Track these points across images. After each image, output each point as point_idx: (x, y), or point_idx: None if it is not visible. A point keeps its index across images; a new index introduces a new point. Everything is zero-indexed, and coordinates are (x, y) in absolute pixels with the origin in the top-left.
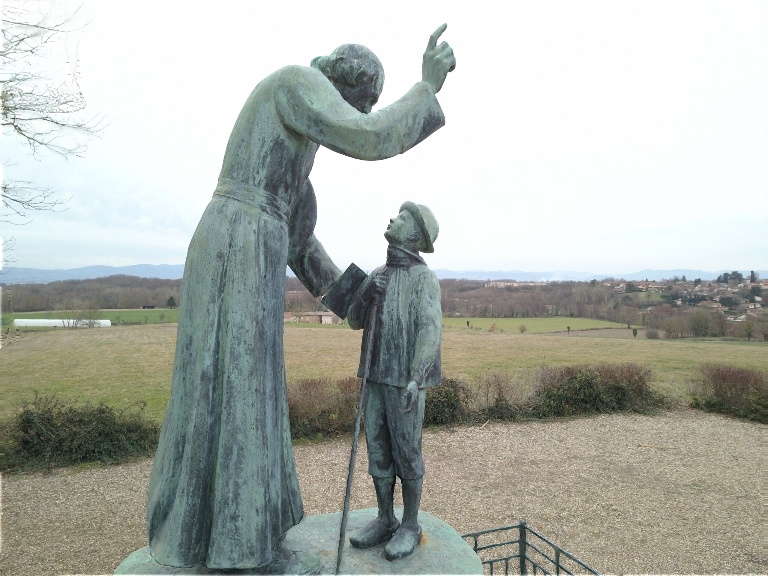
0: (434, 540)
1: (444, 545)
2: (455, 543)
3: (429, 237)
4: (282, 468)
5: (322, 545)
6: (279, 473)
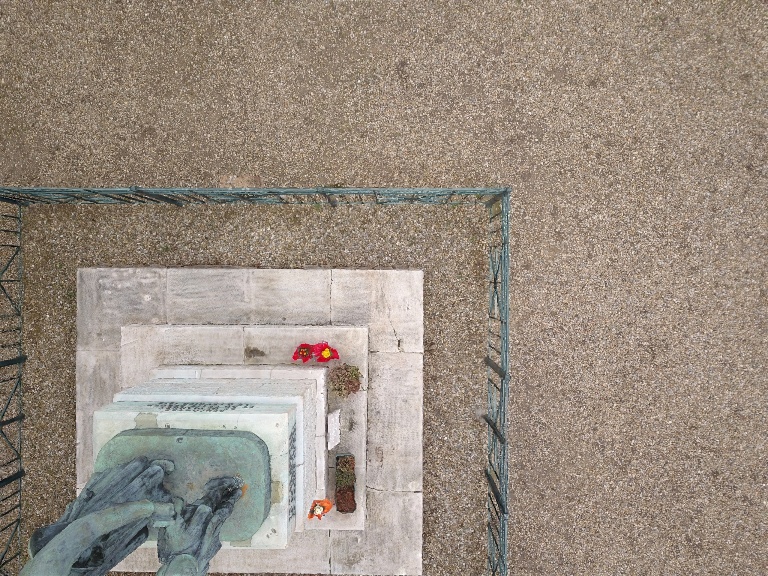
0: (248, 497)
1: (250, 504)
2: (257, 504)
3: None
4: None
5: (193, 478)
6: None
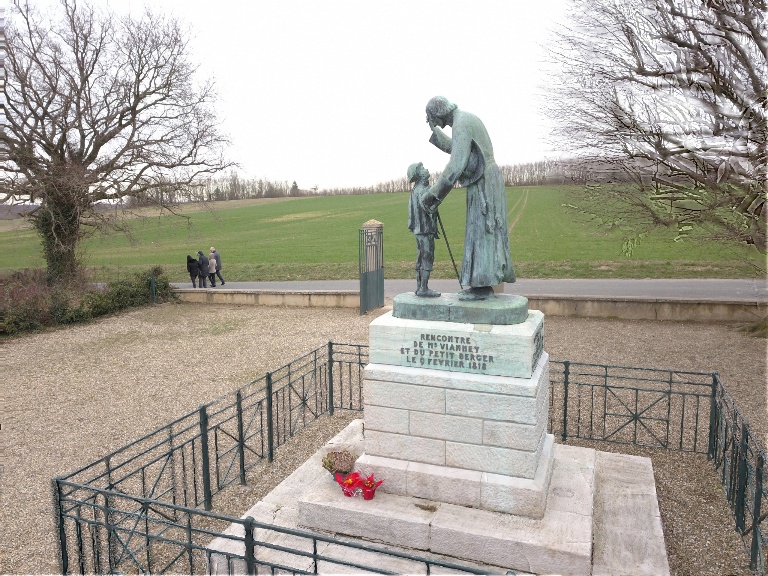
0: None
1: None
2: None
3: None
4: None
5: None
6: None
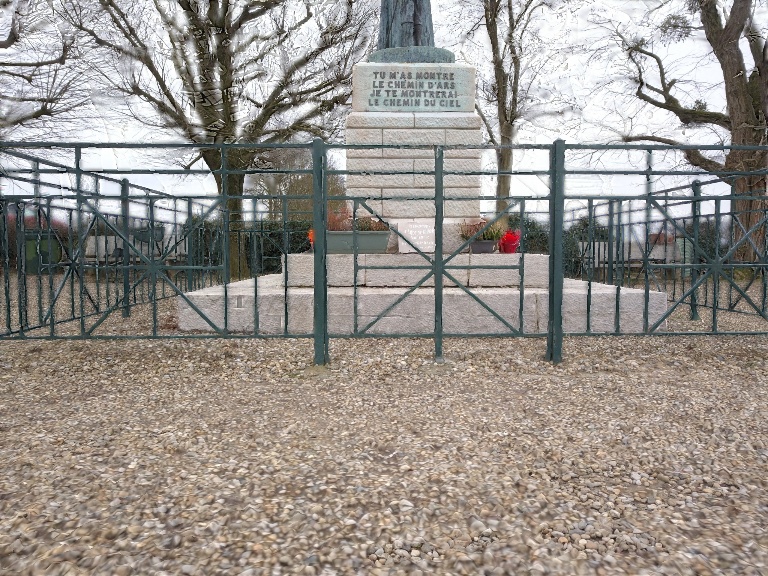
0: None
1: None
2: None
3: None
4: (403, 35)
5: None
6: (397, 35)
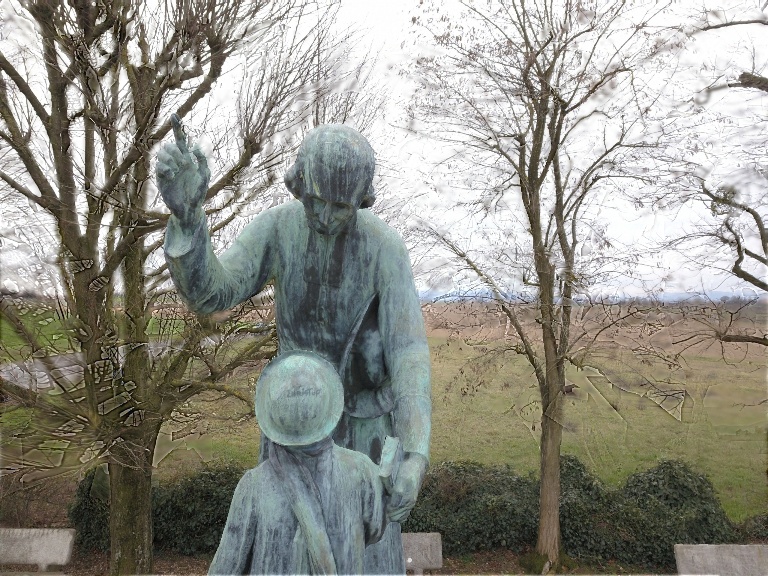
0: None
1: None
2: None
3: (257, 416)
4: None
5: None
6: None
